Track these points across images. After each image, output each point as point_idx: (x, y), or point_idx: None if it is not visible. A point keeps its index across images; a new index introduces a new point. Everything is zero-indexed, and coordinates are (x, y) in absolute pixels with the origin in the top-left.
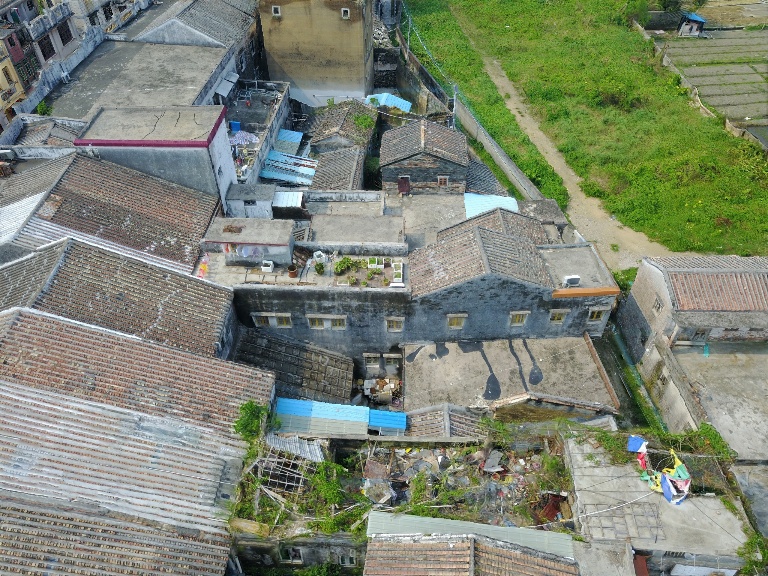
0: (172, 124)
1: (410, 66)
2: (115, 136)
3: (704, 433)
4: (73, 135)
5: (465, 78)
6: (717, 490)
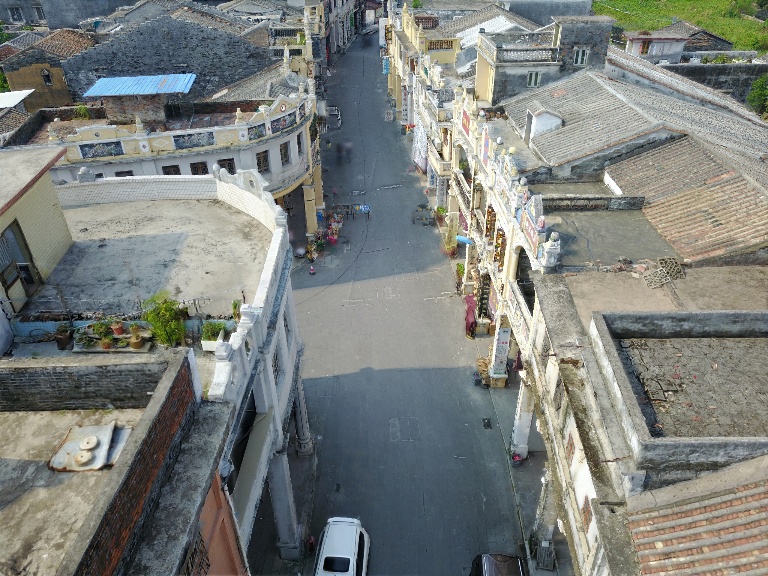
0: None
1: None
2: None
3: None
4: None
5: None
6: None
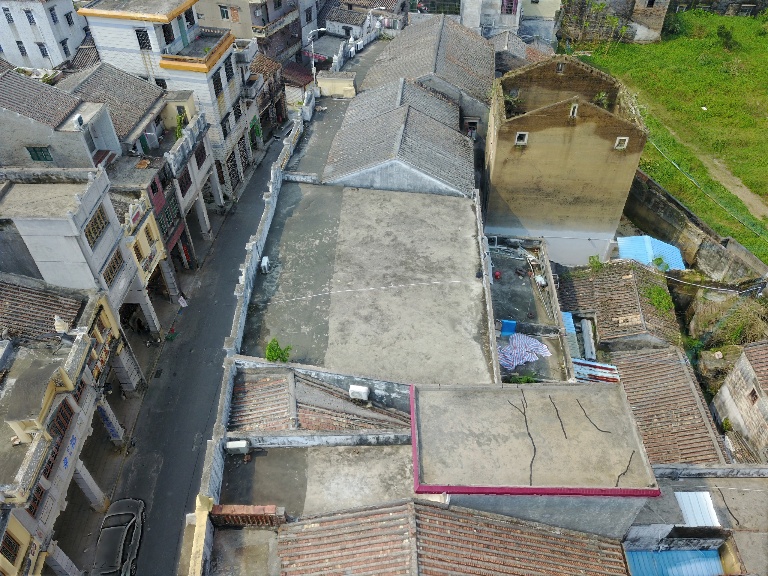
0: (557, 431)
1: (659, 191)
2: (478, 468)
3: None
4: (325, 394)
5: (703, 193)
6: None
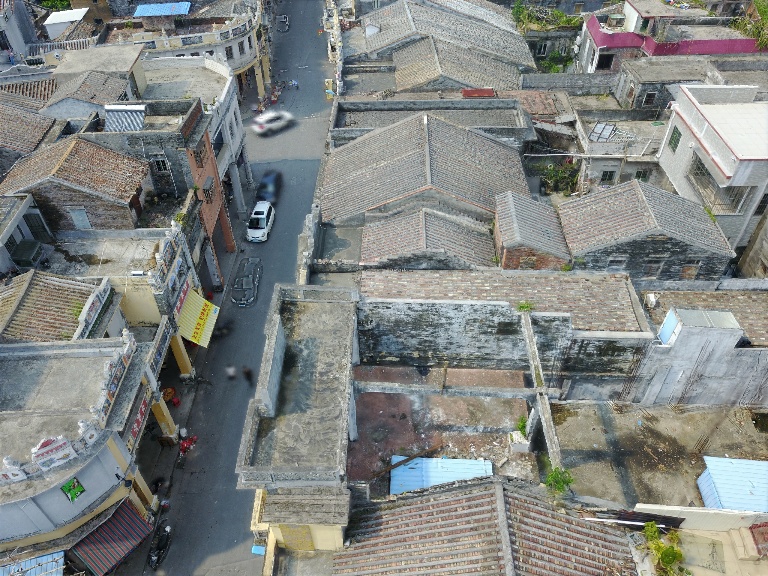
0: None
1: None
2: None
3: (693, 0)
4: None
5: None
6: (699, 7)
